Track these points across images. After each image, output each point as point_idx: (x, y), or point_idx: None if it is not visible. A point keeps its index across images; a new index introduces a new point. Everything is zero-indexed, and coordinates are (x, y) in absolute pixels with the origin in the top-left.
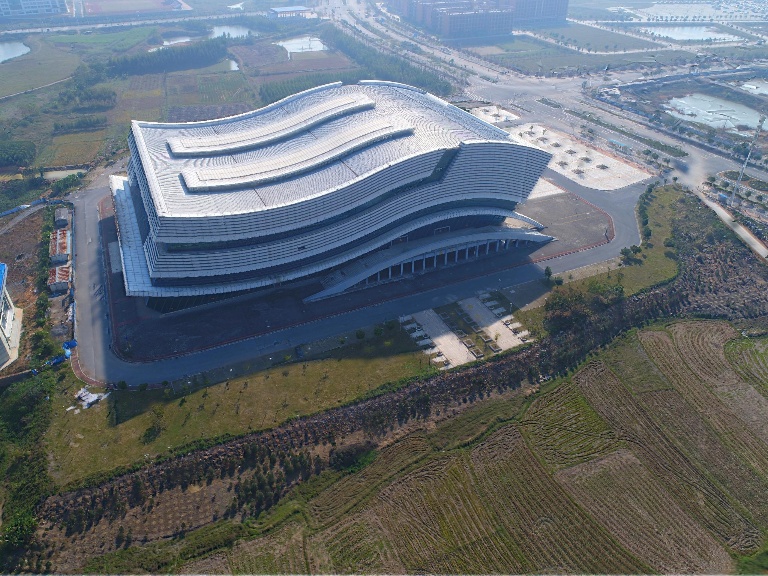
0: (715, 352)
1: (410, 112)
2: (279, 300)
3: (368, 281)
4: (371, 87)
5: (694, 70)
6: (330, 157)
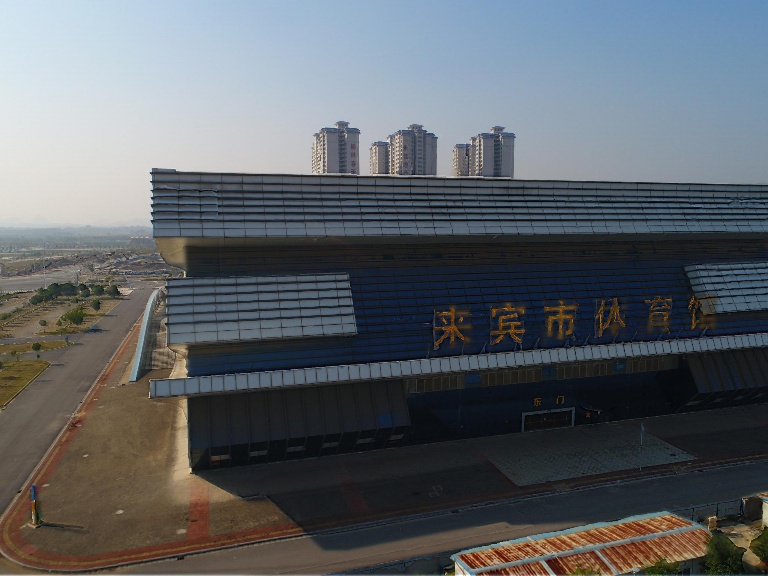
0: None
1: None
2: None
3: None
4: None
5: (117, 259)
6: None
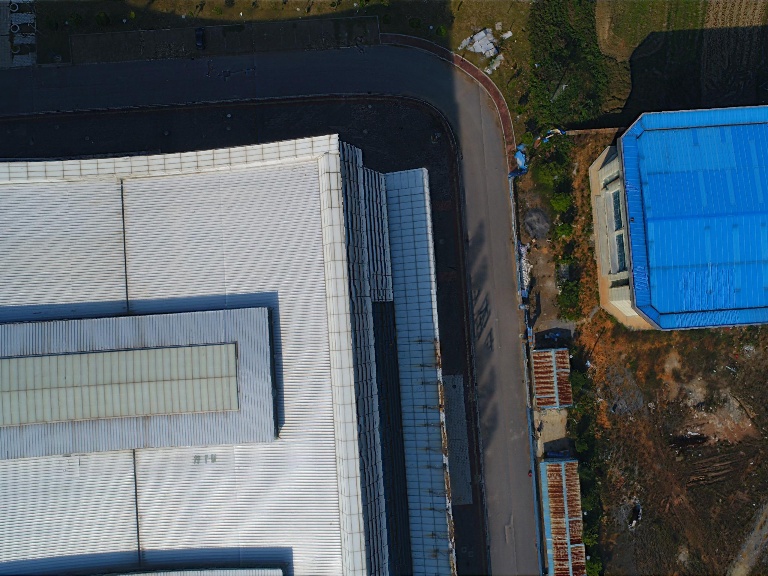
0: None
1: None
2: None
3: None
4: None
5: None
6: None
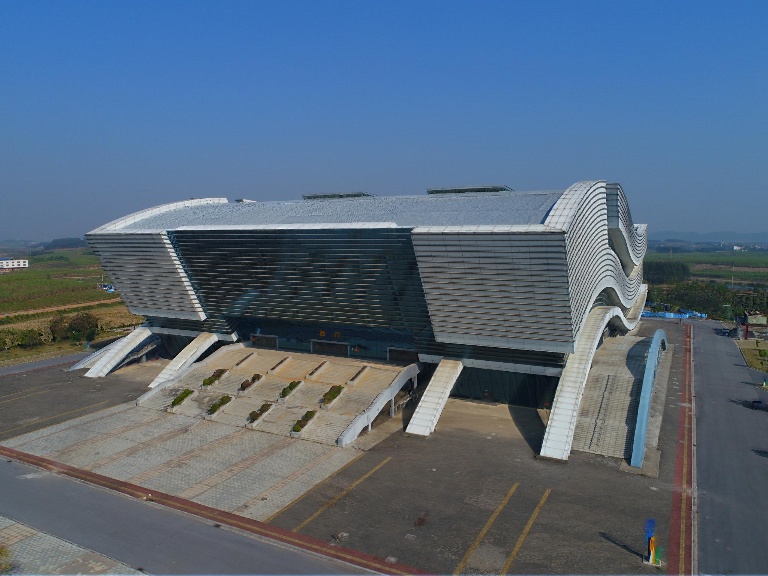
0: None
1: None
2: None
3: None
4: None
5: None
6: None
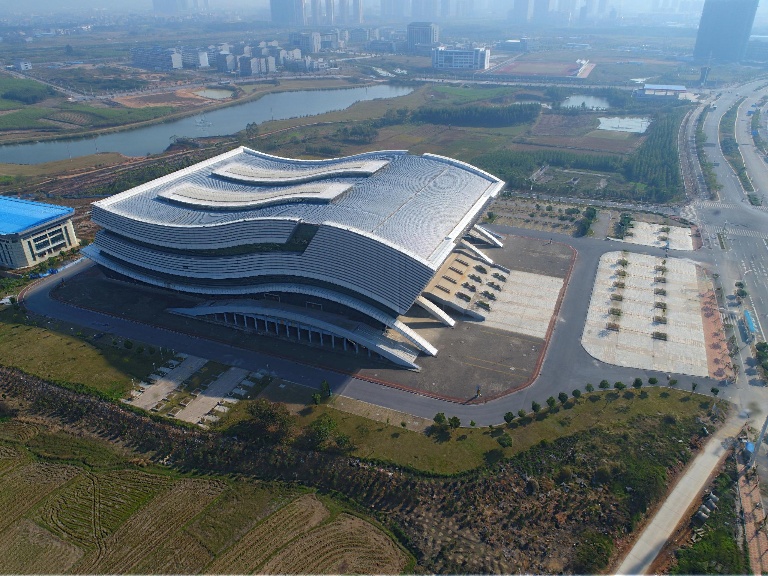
0: (326, 570)
1: (381, 188)
2: (159, 301)
3: (217, 318)
4: (424, 161)
5: None
6: (255, 203)
